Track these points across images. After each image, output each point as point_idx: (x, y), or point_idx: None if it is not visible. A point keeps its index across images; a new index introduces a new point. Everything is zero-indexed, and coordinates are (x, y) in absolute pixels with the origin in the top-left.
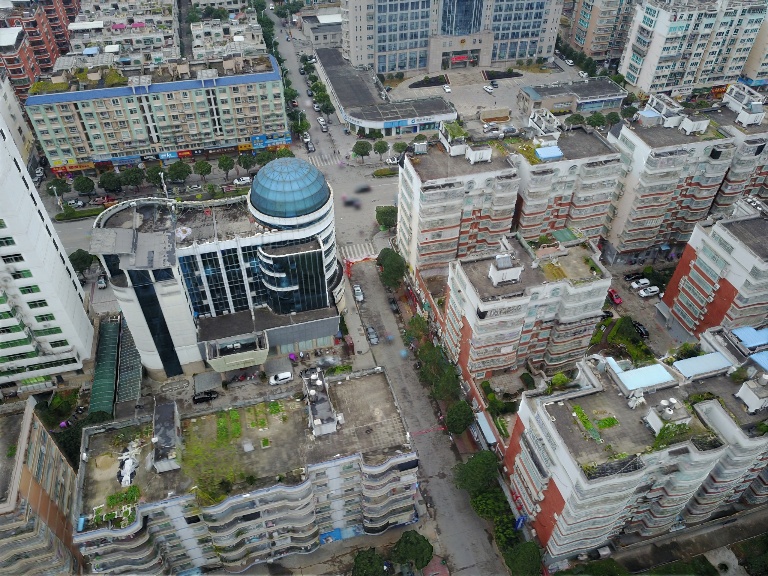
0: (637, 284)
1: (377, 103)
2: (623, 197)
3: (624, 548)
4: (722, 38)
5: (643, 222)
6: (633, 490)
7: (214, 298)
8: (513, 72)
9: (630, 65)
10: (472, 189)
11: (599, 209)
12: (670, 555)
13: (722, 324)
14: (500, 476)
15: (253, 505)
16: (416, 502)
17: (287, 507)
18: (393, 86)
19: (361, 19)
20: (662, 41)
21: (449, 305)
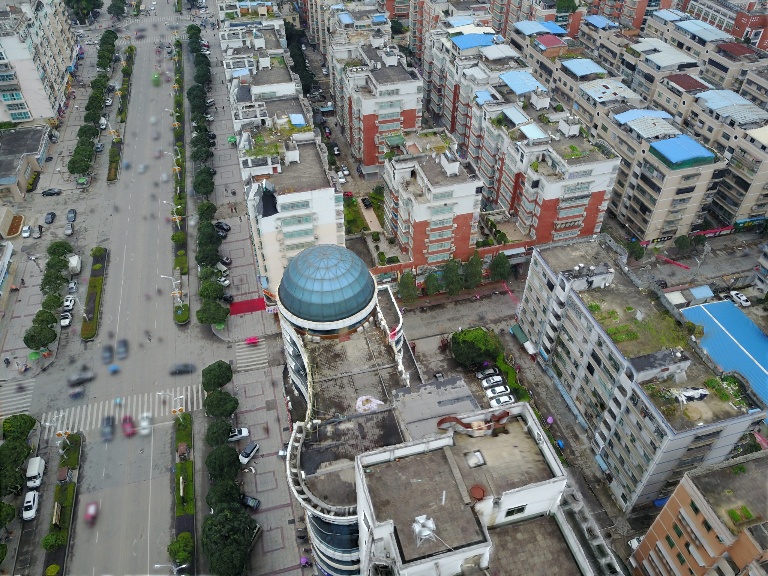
0: None
1: None
2: None
3: None
4: (46, 40)
5: None
6: None
7: None
8: None
9: (9, 106)
10: None
11: None
12: None
13: None
14: None
15: None
16: None
17: None
18: None
19: None
20: (31, 64)
21: (430, 232)
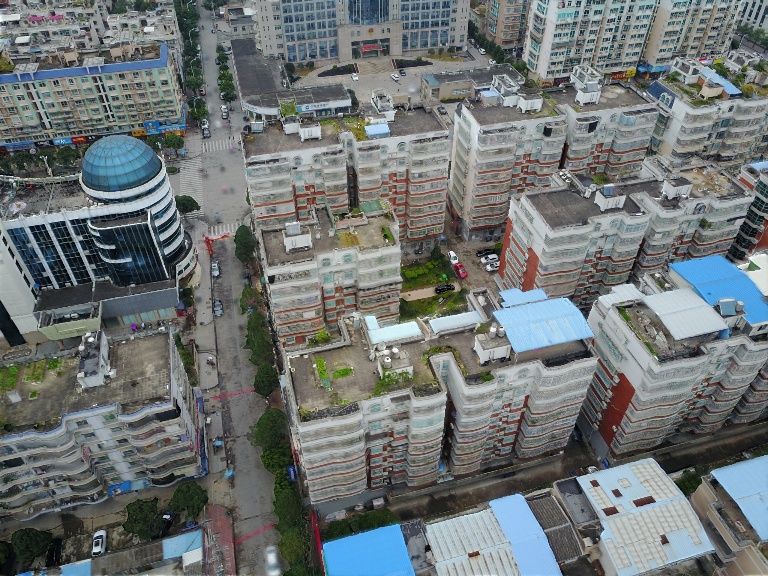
0: (486, 259)
1: (277, 91)
2: (468, 175)
3: (393, 498)
4: (614, 24)
5: (487, 199)
6: (359, 435)
7: (53, 270)
8: (423, 61)
9: (530, 52)
10: (300, 165)
11: (437, 185)
12: (444, 506)
13: None
14: (289, 432)
15: (10, 451)
16: (218, 459)
17: (54, 455)
18: (303, 75)
19: (266, 9)
20: (553, 28)
21: None
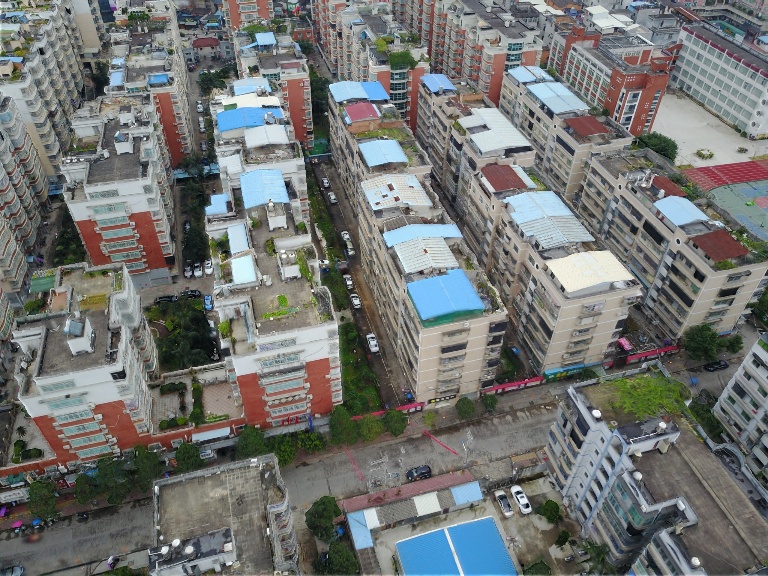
0: None
1: None
2: None
3: None
4: None
5: (8, 251)
6: None
7: None
8: None
9: None
10: None
11: None
12: None
13: (161, 241)
14: None
15: None
16: None
17: None
18: None
19: None
20: None
21: (59, 428)
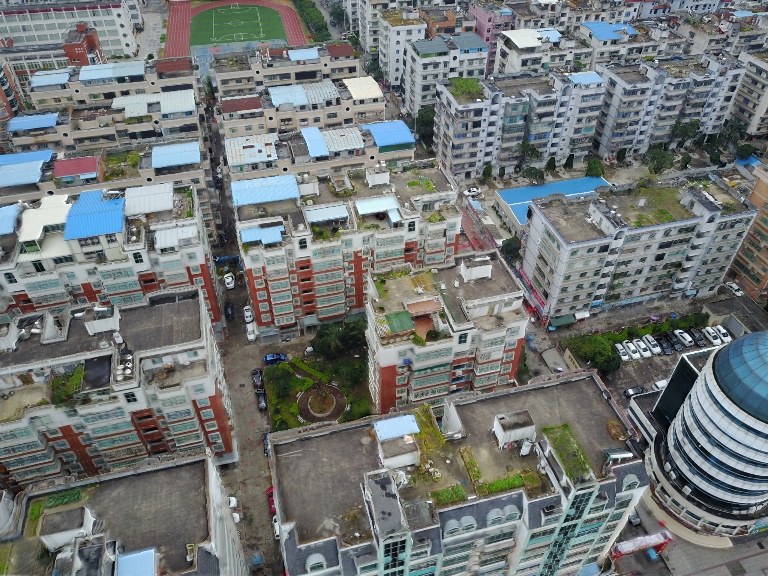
0: None
1: None
2: None
3: None
4: None
5: None
6: None
7: None
8: None
9: None
10: None
11: None
12: None
13: None
14: None
15: None
16: None
17: None
18: None
19: None
20: None
21: None
